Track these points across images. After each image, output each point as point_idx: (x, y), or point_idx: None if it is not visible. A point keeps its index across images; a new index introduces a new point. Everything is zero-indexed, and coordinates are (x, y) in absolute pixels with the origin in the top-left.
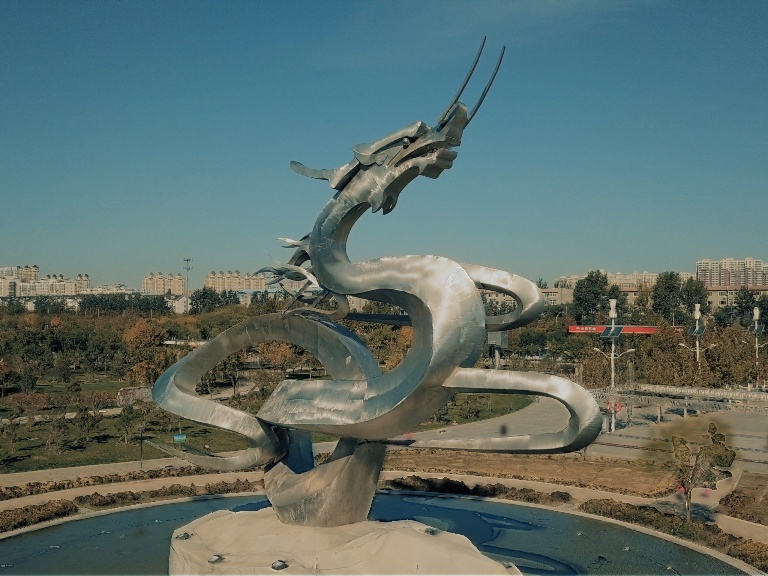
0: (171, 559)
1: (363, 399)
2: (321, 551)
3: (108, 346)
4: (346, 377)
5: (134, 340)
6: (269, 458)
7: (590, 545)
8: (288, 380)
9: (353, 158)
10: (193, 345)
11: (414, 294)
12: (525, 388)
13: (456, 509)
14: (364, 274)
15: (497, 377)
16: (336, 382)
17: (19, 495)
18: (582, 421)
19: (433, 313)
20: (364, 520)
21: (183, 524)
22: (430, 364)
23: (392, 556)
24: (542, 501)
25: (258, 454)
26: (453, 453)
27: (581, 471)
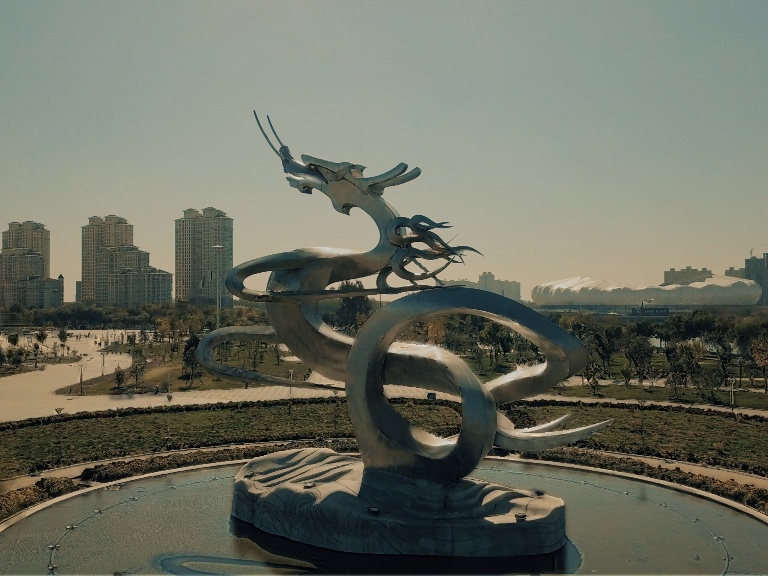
0: None
1: None
2: None
3: None
4: None
5: None
6: None
7: None
8: None
9: None
10: None
11: None
12: None
13: None
14: None
15: (258, 330)
16: None
17: None
18: None
19: None
20: None
21: None
22: None
23: None
24: None
25: None
26: None
27: None
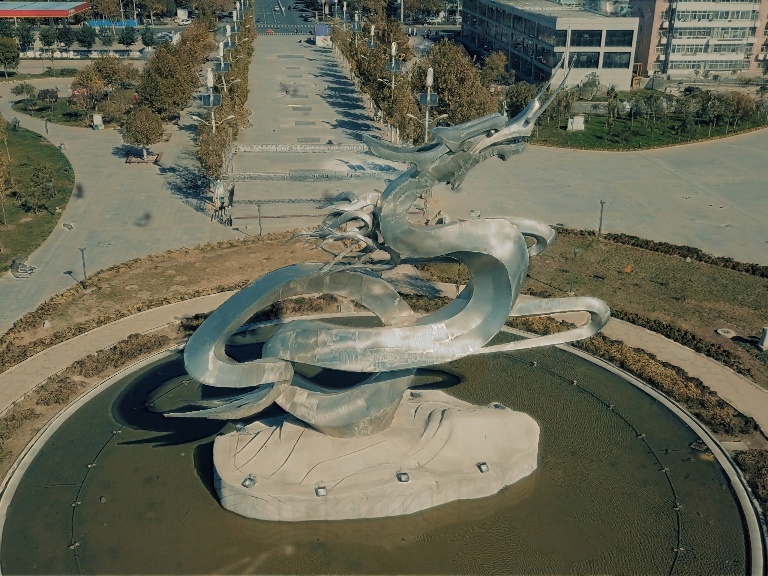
0: (251, 505)
1: (449, 339)
2: (410, 452)
3: None
4: (395, 315)
5: None
6: None
7: None
8: (347, 330)
9: (443, 146)
10: None
11: (491, 254)
12: (571, 309)
13: None
14: (440, 240)
15: (550, 304)
16: (414, 328)
17: None
18: None
19: (508, 268)
20: None
21: (118, 457)
22: None
23: (465, 436)
24: (324, 308)
25: None
26: (148, 262)
27: (279, 256)
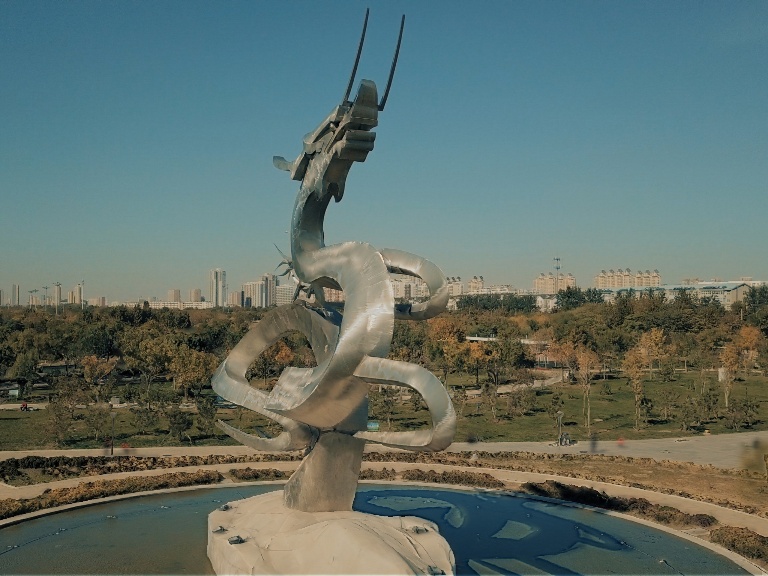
0: None
1: (304, 386)
2: (281, 533)
3: (413, 341)
4: None
5: (435, 336)
6: (304, 443)
7: (660, 575)
8: None
9: None
10: (447, 340)
11: (337, 281)
12: (397, 379)
13: (564, 519)
14: (315, 262)
15: (384, 367)
16: (298, 369)
17: (195, 464)
18: (437, 417)
19: (346, 300)
20: (347, 510)
21: None
22: (336, 352)
23: (322, 545)
24: (674, 522)
25: (288, 438)
26: (652, 463)
27: None
